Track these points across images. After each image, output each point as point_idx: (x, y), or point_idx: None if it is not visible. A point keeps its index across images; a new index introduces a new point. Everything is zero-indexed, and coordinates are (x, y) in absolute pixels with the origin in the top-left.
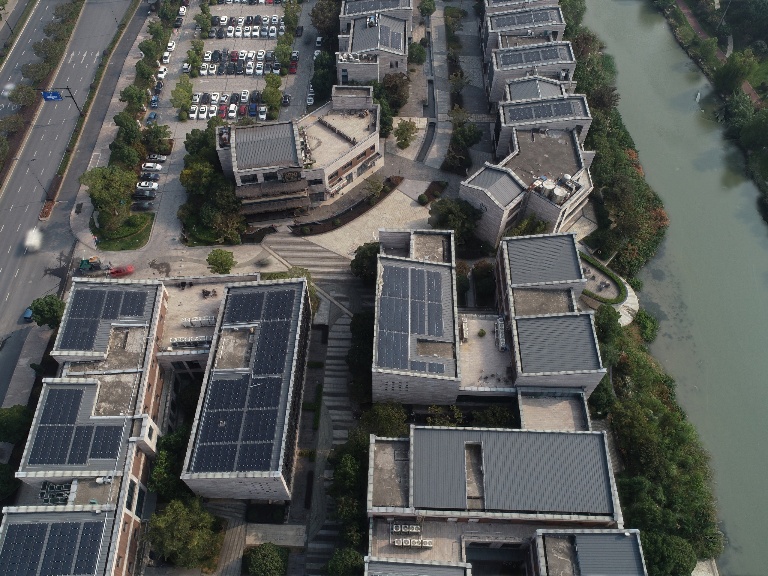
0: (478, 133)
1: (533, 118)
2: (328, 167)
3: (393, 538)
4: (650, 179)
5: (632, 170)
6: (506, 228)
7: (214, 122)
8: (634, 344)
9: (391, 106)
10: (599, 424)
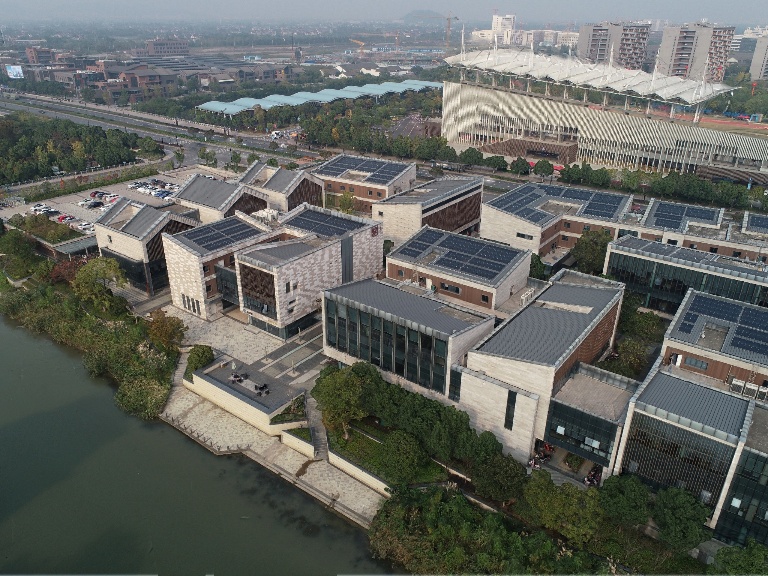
0: None
1: None
2: None
3: None
4: None
5: None
6: None
7: None
8: None
9: None
10: None
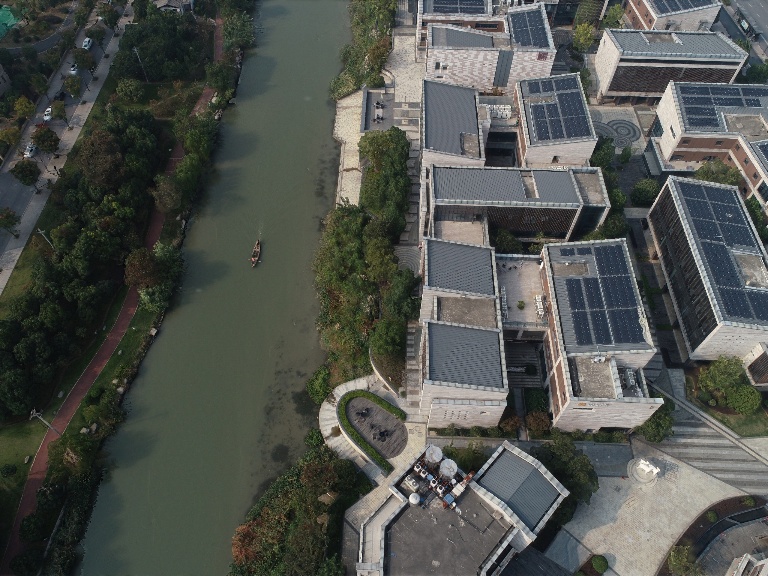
0: None
1: None
2: None
3: None
4: None
5: None
6: None
7: None
8: (343, 358)
9: None
10: None
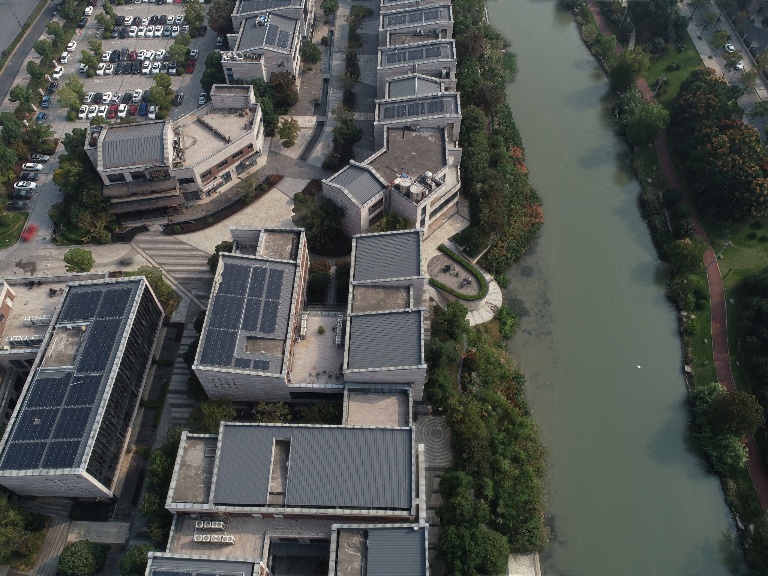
0: (358, 131)
1: (406, 116)
2: (198, 166)
3: (197, 534)
4: (534, 176)
5: (512, 167)
6: (371, 226)
7: (95, 122)
8: (490, 340)
9: (281, 105)
10: (439, 420)
